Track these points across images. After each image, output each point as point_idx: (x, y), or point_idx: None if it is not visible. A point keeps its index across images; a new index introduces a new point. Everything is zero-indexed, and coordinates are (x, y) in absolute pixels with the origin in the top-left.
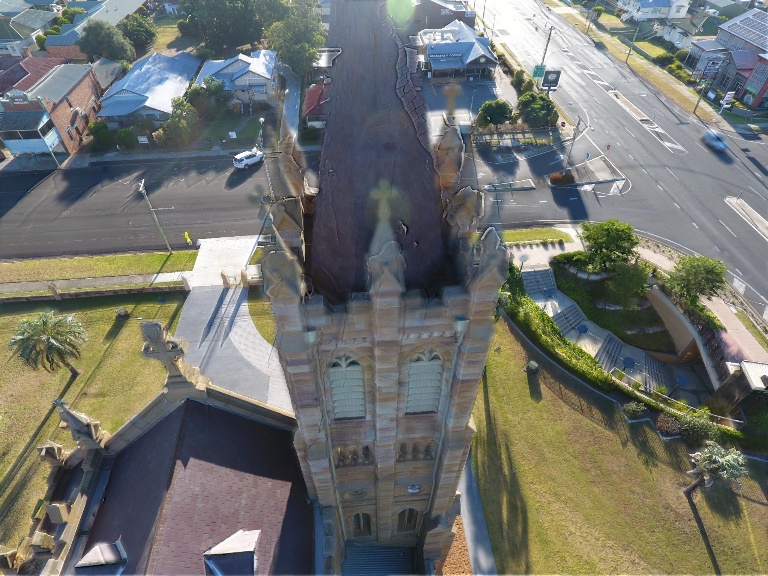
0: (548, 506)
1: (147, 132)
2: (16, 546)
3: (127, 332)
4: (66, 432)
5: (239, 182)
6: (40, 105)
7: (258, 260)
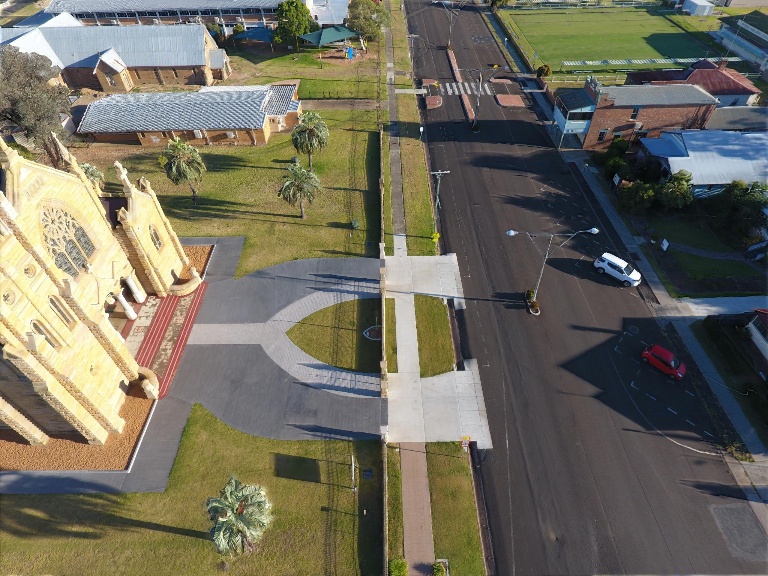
0: (19, 567)
1: (627, 177)
2: (191, 226)
3: (337, 232)
4: (256, 224)
5: (566, 269)
6: (597, 97)
7: (421, 301)
